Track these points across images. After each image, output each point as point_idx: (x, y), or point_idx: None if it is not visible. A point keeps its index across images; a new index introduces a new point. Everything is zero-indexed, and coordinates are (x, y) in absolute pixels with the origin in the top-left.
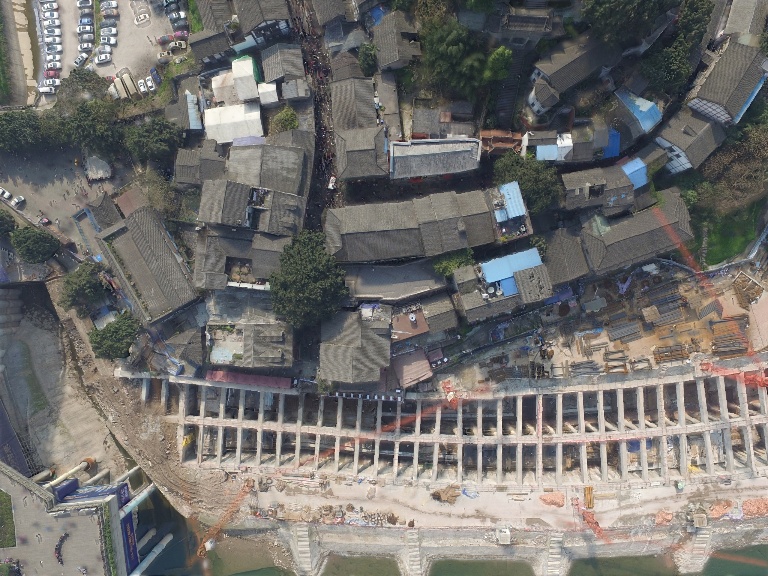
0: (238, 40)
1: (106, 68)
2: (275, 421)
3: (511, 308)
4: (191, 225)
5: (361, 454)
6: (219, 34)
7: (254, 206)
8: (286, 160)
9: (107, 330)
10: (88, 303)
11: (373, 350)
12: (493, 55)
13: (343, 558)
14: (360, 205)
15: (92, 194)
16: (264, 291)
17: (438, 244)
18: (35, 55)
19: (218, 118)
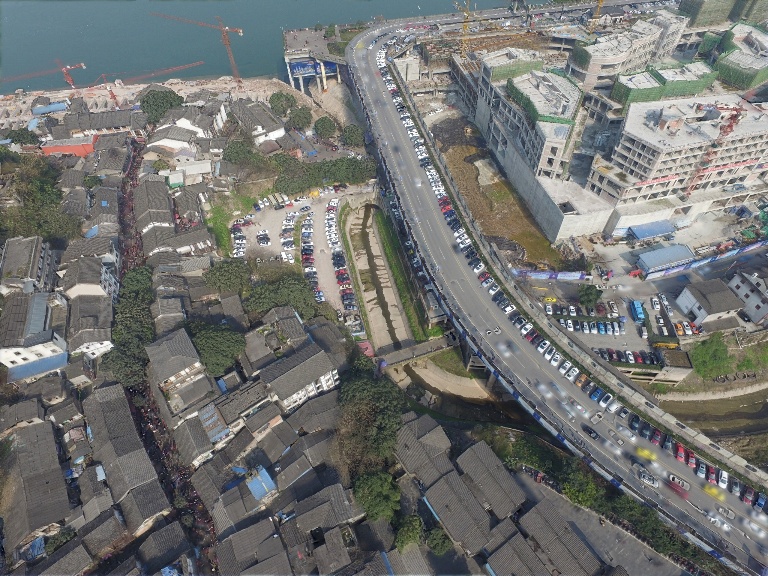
0: None
1: None
2: None
3: None
4: None
5: None
6: (184, 187)
7: None
8: None
9: (280, 97)
10: None
11: None
12: (6, 148)
13: None
14: None
15: (307, 162)
16: None
17: None
18: (368, 244)
19: (202, 167)
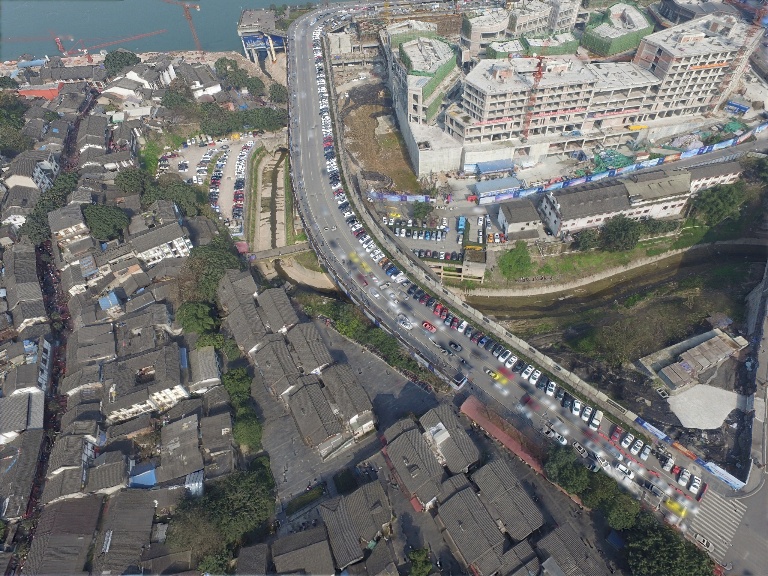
0: None
1: None
2: None
3: None
4: None
5: None
6: (122, 122)
7: None
8: None
9: (222, 61)
10: None
11: None
12: None
13: None
14: None
15: None
16: None
17: None
18: (275, 179)
19: (144, 111)
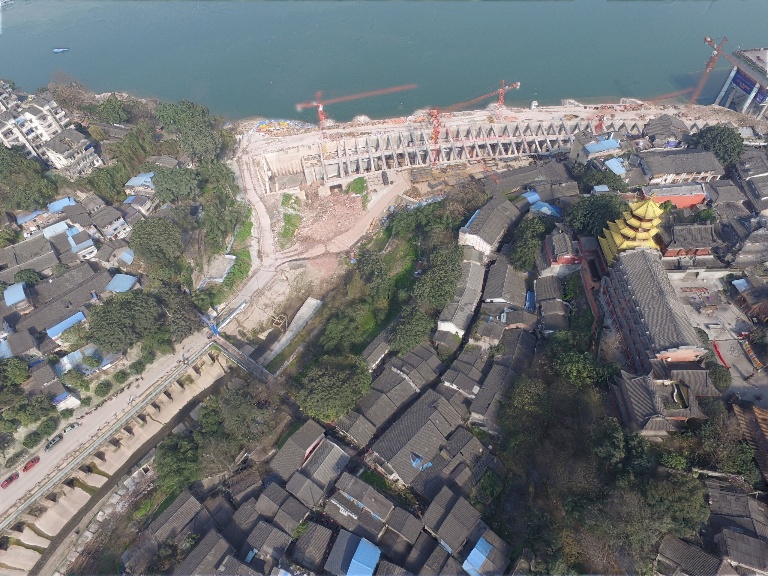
0: None
1: None
2: None
3: None
4: None
5: None
6: None
7: None
8: None
9: None
10: None
11: (659, 129)
12: None
13: None
14: None
15: None
16: None
17: None
18: None
19: None
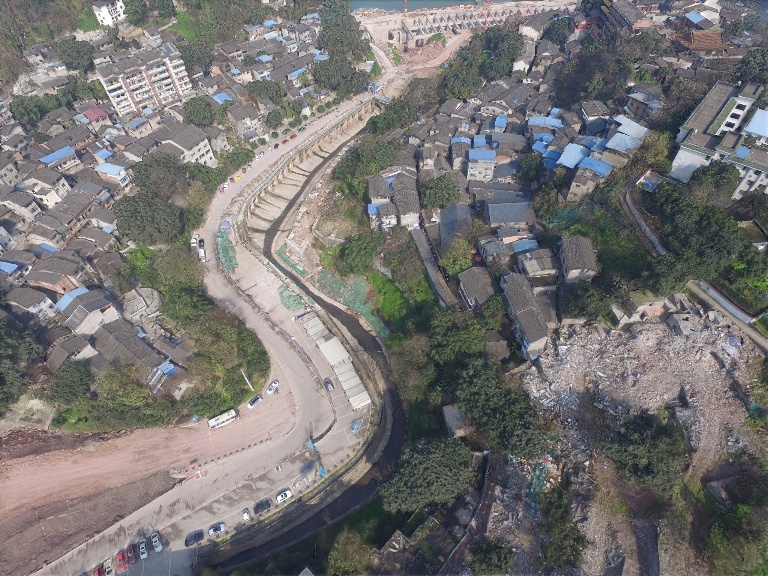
0: None
1: None
2: None
3: None
4: None
5: None
6: None
7: None
8: None
9: None
10: None
11: None
12: None
13: None
14: None
15: None
16: None
17: None
18: None
19: None
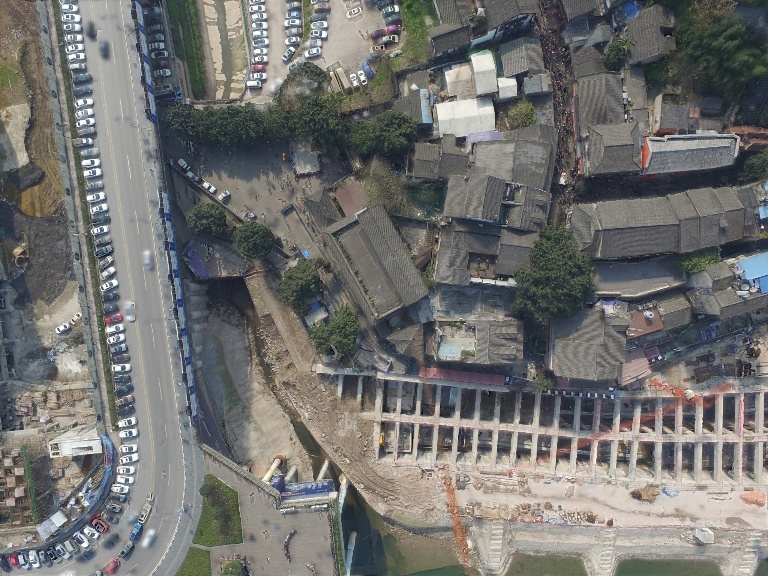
0: (478, 34)
1: (315, 62)
2: (470, 418)
3: (764, 305)
4: (410, 220)
5: (542, 452)
6: (463, 28)
7: (506, 201)
8: (535, 155)
9: (336, 326)
10: (303, 298)
11: (612, 347)
12: None
13: (528, 557)
14: (610, 201)
15: (299, 189)
16: (501, 287)
17: (694, 240)
18: (224, 49)
19: (451, 113)
